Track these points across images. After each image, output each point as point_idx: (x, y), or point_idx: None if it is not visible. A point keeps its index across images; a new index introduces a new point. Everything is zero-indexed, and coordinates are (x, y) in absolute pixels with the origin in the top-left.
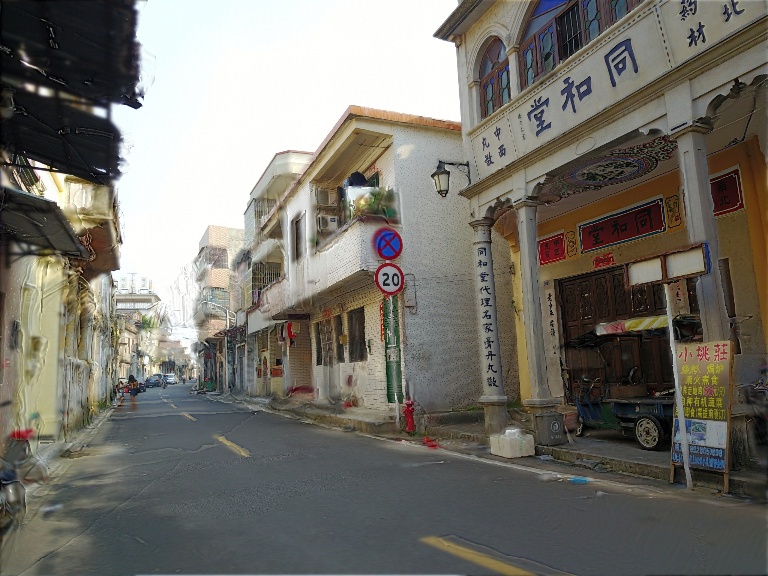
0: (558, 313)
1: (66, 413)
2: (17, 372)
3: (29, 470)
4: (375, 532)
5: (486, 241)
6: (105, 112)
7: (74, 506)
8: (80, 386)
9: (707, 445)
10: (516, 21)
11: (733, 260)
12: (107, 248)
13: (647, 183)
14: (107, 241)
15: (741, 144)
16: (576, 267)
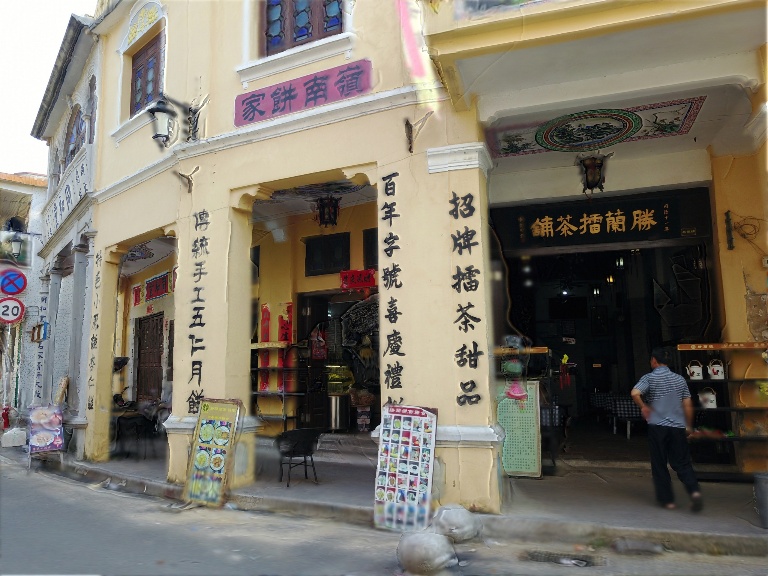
0: (135, 343)
1: None
2: None
3: None
4: None
5: None
6: None
7: None
8: None
9: None
10: (62, 143)
11: None
12: None
13: (164, 260)
14: None
15: None
16: (142, 311)
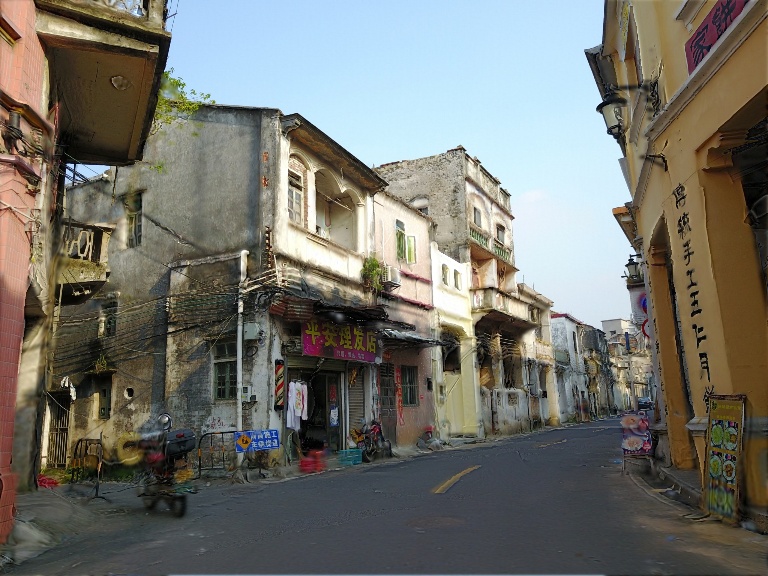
0: None
1: (491, 422)
2: (429, 401)
3: (430, 444)
4: None
5: None
6: (382, 322)
7: None
8: (514, 406)
9: None
10: None
11: None
12: (508, 321)
13: None
14: (504, 318)
15: None
16: None
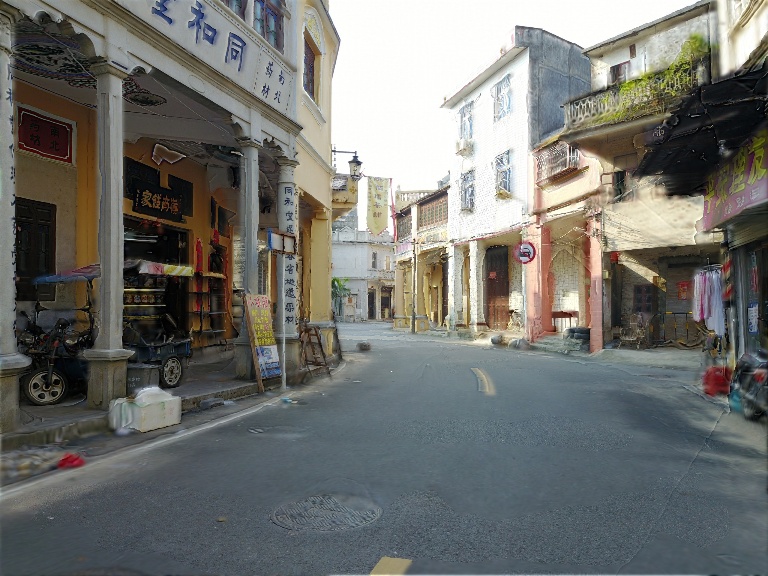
0: None
1: None
2: None
3: None
4: (507, 398)
5: (8, 56)
6: None
7: None
8: None
9: (273, 361)
10: None
11: (61, 209)
12: None
13: None
14: None
15: (87, 108)
16: None
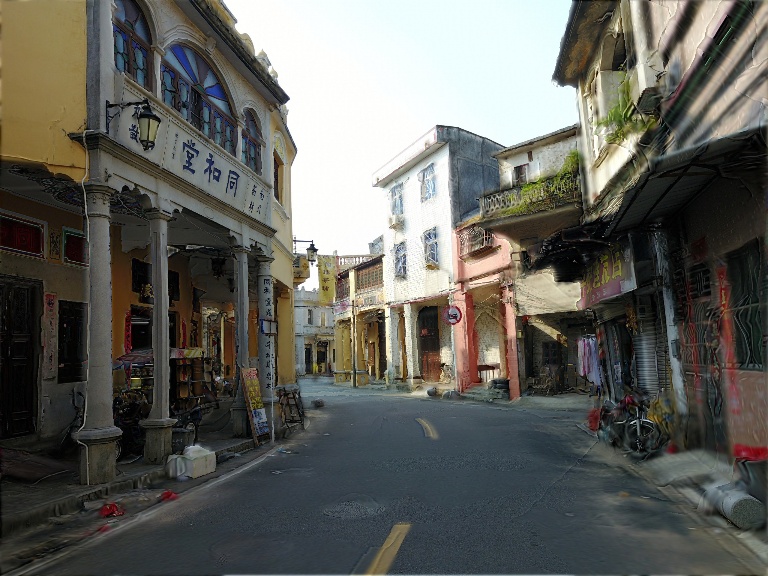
0: None
1: None
2: None
3: None
4: (448, 440)
5: None
6: None
7: (612, 476)
8: None
9: None
10: None
11: None
12: None
13: (40, 203)
14: None
15: None
16: None
